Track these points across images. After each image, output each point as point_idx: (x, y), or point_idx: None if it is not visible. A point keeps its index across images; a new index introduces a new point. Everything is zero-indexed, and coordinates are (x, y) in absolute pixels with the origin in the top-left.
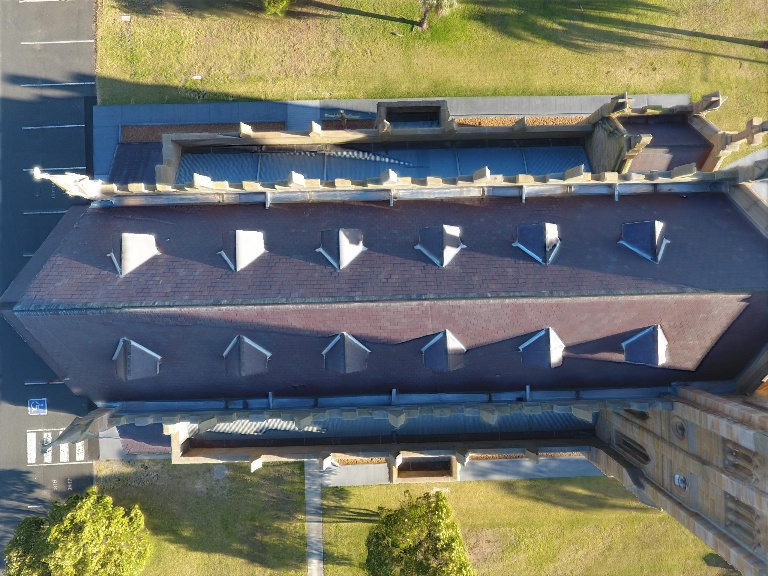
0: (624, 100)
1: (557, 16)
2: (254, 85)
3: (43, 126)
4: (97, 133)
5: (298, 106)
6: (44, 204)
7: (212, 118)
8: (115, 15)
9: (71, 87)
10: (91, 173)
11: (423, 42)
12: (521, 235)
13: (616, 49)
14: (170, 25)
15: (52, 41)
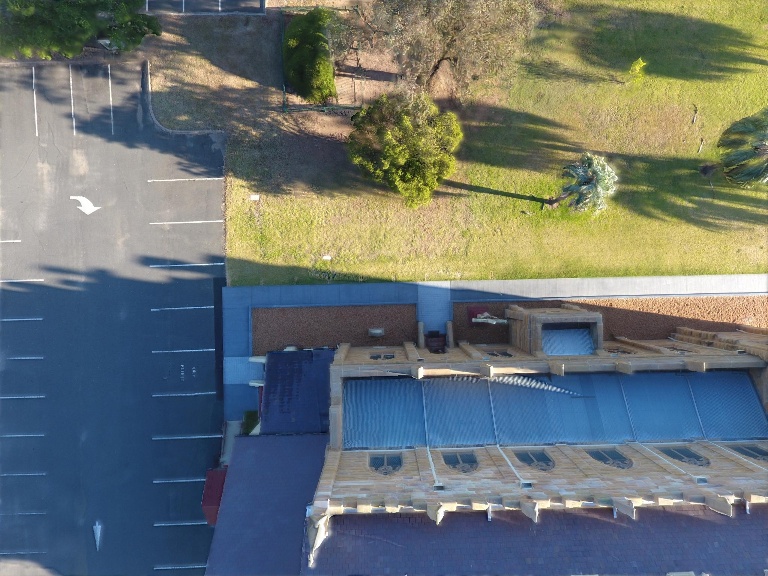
0: None
1: (687, 193)
2: (384, 265)
3: (172, 308)
4: (226, 315)
5: (429, 287)
6: (173, 387)
7: (342, 299)
8: (244, 195)
9: (200, 268)
10: (220, 355)
11: (553, 221)
12: None
13: (746, 227)
14: (299, 204)
15: (181, 221)
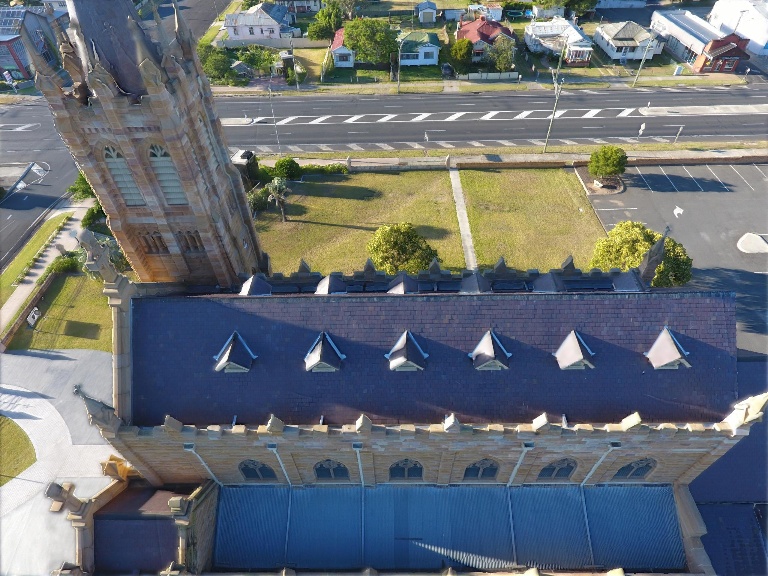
0: (173, 573)
1: None
2: None
3: None
4: None
5: None
6: None
7: None
8: None
9: None
10: None
11: None
12: (338, 362)
13: None
14: None
15: None
